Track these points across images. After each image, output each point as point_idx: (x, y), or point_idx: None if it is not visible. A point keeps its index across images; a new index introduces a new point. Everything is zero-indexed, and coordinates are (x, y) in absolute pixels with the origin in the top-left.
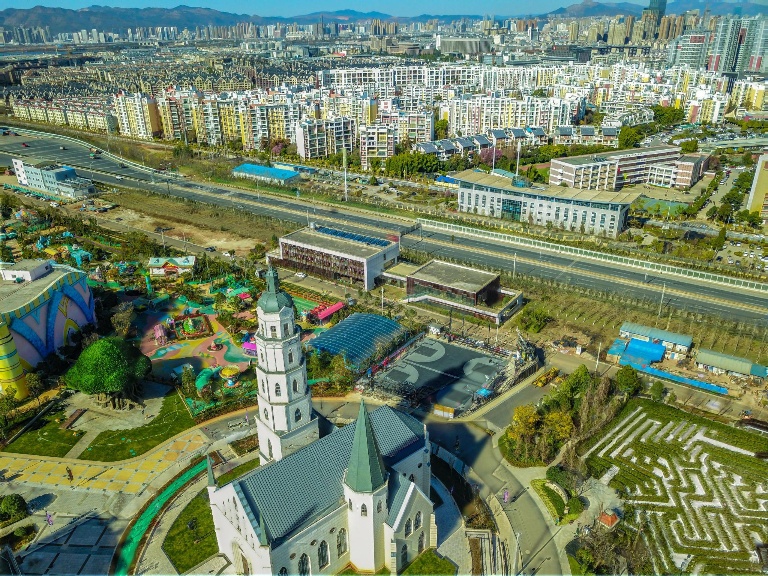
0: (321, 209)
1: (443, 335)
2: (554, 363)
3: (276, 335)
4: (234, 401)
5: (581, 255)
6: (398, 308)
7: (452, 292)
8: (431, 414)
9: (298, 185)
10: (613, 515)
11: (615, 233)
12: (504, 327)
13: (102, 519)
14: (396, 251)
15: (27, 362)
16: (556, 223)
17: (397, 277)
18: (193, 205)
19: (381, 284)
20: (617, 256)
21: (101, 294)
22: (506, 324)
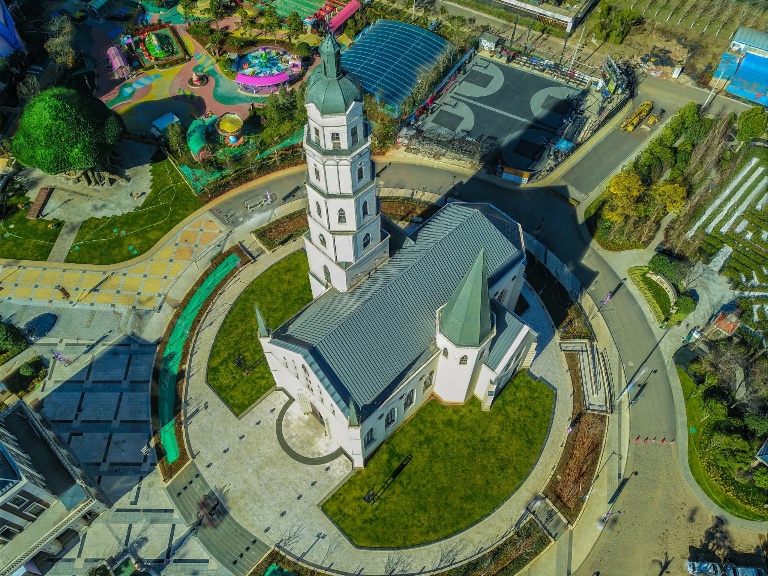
0: None
1: (498, 52)
2: (644, 92)
3: (340, 145)
4: (244, 168)
5: None
6: (432, 6)
7: None
8: (498, 178)
9: None
10: (736, 321)
11: None
12: (576, 35)
13: (122, 345)
14: None
15: None
16: None
17: None
18: None
19: None
20: None
21: None
22: (578, 30)
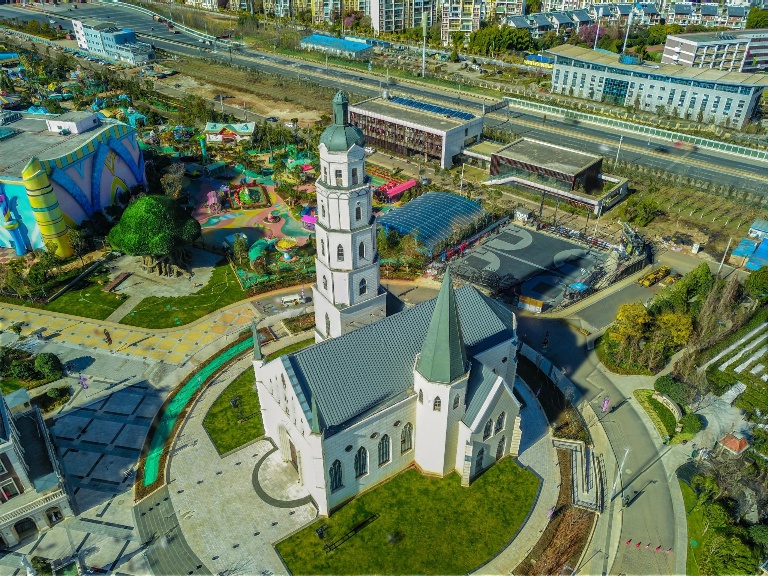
0: (395, 84)
1: (530, 222)
2: (664, 261)
3: (342, 182)
4: (290, 276)
5: (698, 145)
6: (478, 190)
7: (545, 174)
8: (514, 307)
9: (370, 59)
10: (743, 439)
11: (741, 122)
12: (603, 218)
13: (140, 388)
14: (480, 127)
15: (71, 219)
16: (668, 109)
17: (479, 156)
18: (256, 75)
19: (460, 164)
20: (744, 147)
21: (154, 158)
22: (606, 215)
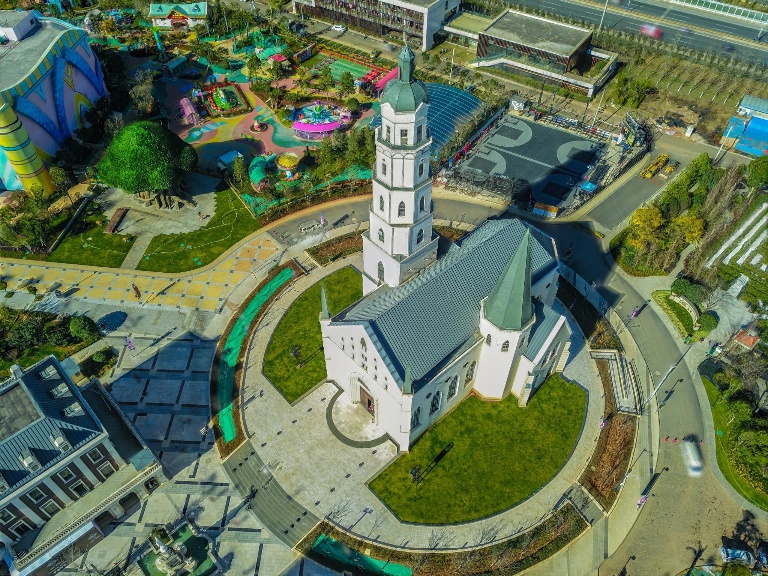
0: None
1: (527, 111)
2: (660, 148)
3: (407, 141)
4: (299, 197)
5: (676, 1)
6: None
7: (537, 55)
8: (529, 213)
9: None
10: (756, 336)
11: None
12: (597, 100)
13: (185, 340)
14: None
15: (43, 151)
16: None
17: (462, 33)
18: None
19: (440, 41)
20: (722, 3)
21: (100, 55)
22: (598, 96)
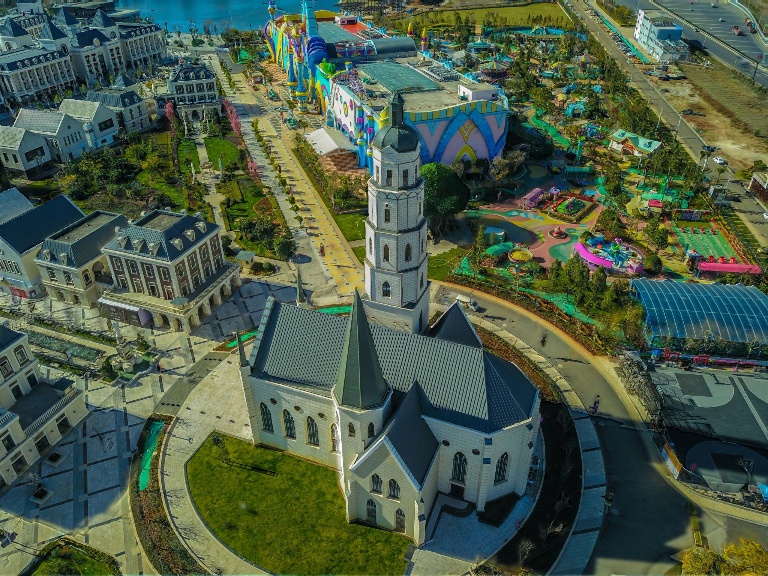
0: None
1: None
2: None
3: (379, 179)
4: None
5: None
6: None
7: None
8: (657, 451)
9: None
10: None
11: None
12: None
13: (304, 293)
14: None
15: None
16: None
17: None
18: None
19: None
20: None
21: (545, 146)
22: None
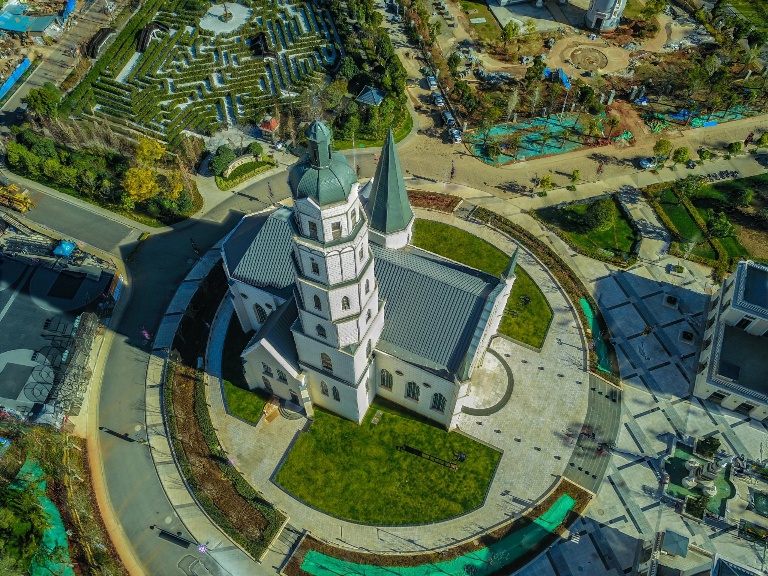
0: None
1: None
2: None
3: None
4: None
5: None
6: None
7: None
8: (117, 305)
9: None
10: None
11: None
12: None
13: None
14: None
15: None
16: None
17: None
18: None
19: None
20: None
21: None
22: None
